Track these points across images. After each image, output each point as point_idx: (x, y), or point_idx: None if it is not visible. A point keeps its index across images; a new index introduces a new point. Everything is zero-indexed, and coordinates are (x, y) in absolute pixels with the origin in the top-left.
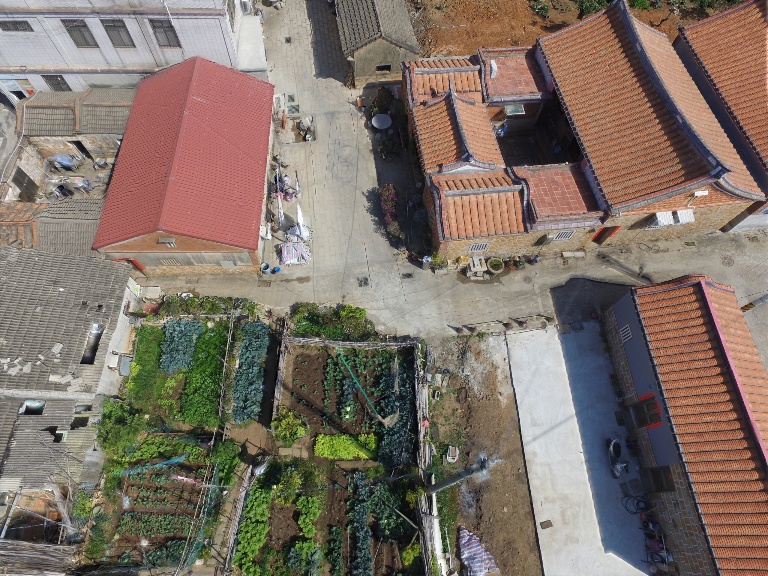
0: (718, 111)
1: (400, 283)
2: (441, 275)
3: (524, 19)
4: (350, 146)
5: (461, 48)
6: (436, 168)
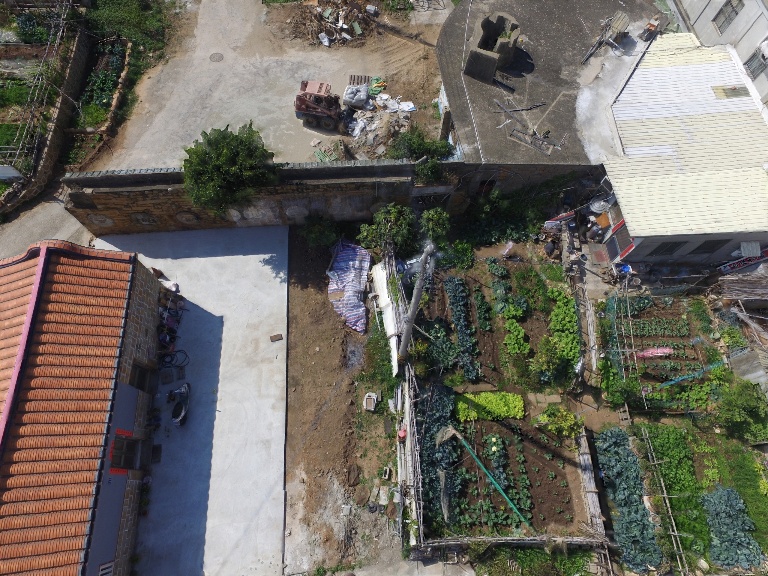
0: None
1: None
2: None
3: None
4: None
5: None
6: None
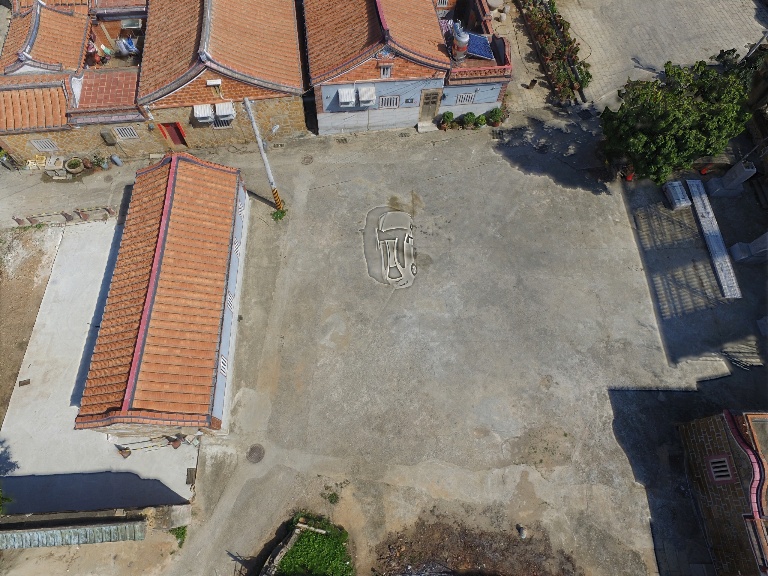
0: (302, 17)
1: None
2: (27, 175)
3: None
4: None
5: None
6: (2, 70)
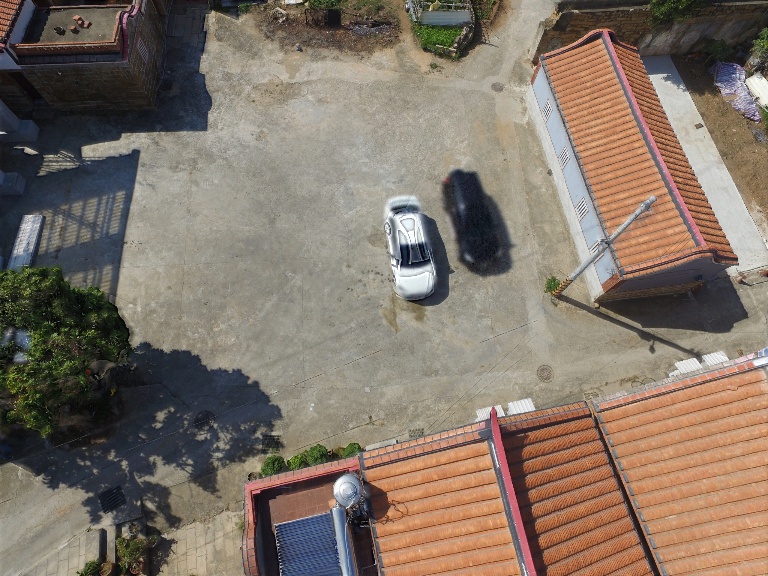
0: None
1: None
2: None
3: None
4: None
5: None
6: None
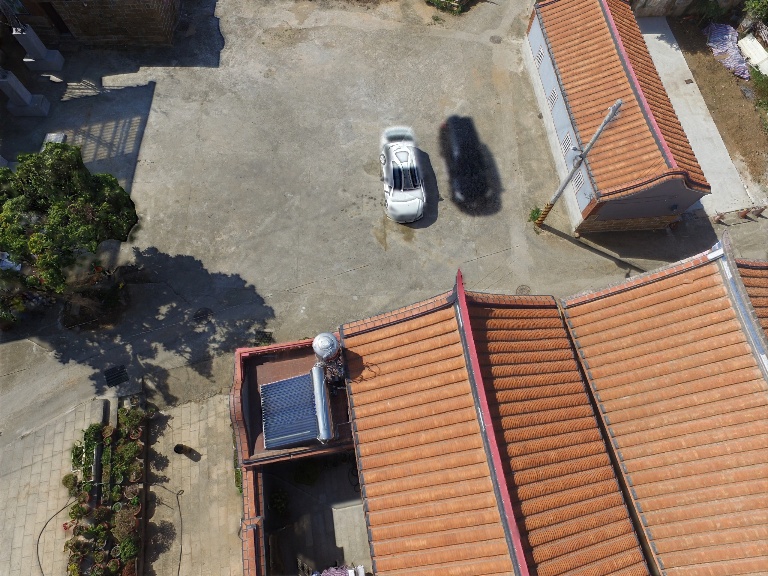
0: None
1: None
2: None
3: None
4: None
5: None
6: None
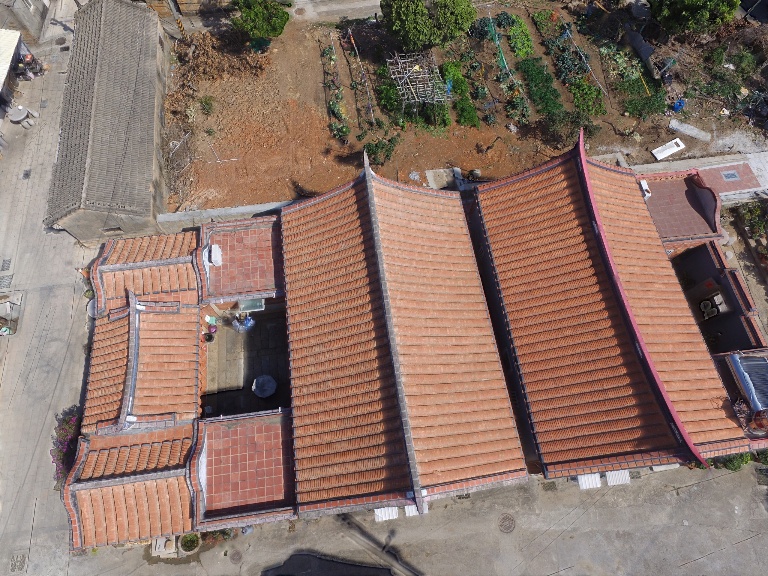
0: (499, 322)
1: (66, 564)
2: (123, 550)
3: (315, 146)
4: (59, 340)
5: (223, 194)
6: (93, 427)
